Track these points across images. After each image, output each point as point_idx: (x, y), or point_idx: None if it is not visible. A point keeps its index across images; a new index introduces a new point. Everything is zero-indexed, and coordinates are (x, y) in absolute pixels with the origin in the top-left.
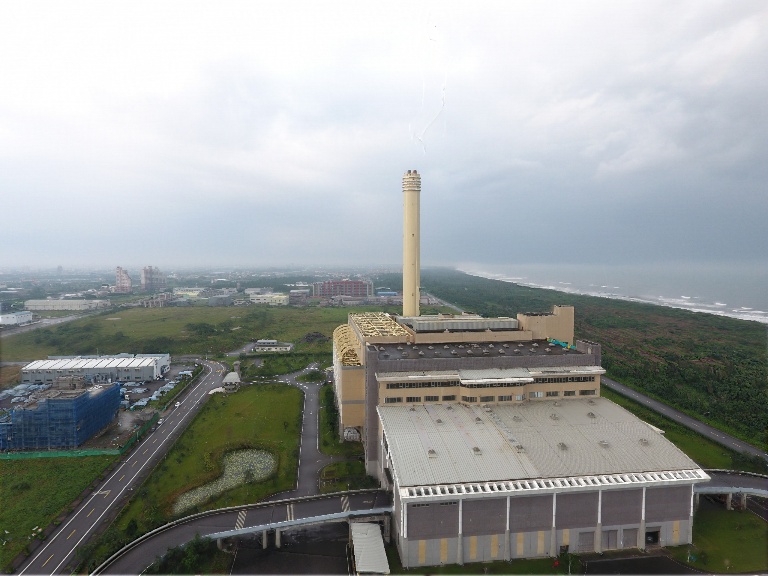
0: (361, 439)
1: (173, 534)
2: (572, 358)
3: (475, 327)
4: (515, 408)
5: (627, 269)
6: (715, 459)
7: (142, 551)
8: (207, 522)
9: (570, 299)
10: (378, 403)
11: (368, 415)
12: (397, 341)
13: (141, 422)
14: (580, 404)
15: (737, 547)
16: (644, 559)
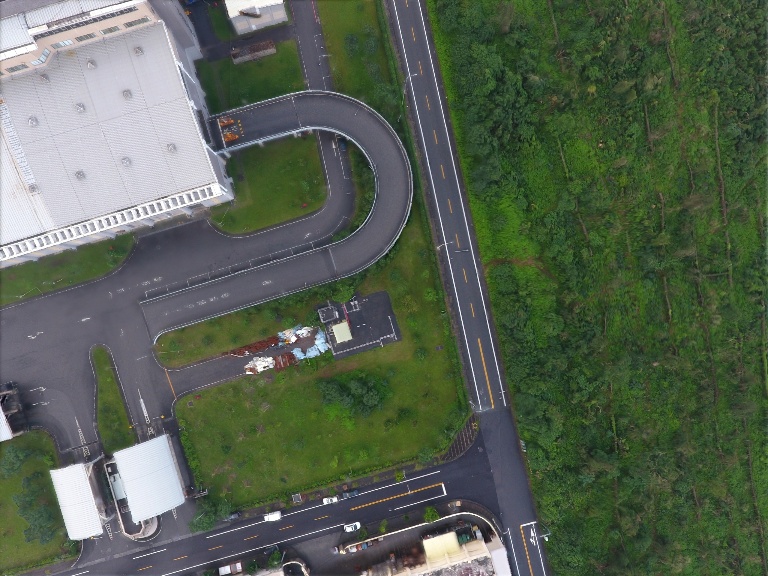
0: None
1: None
2: None
3: None
4: (34, 86)
5: None
6: (343, 22)
7: None
8: None
9: None
10: None
11: None
12: None
13: None
14: (123, 55)
15: (267, 200)
16: (186, 226)
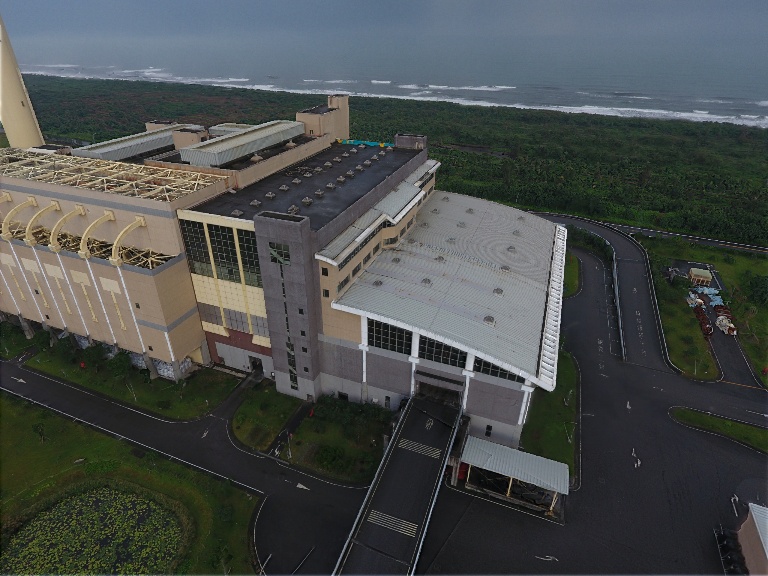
0: (199, 363)
1: None
2: (420, 157)
3: (272, 142)
4: (425, 230)
5: (129, 42)
6: None
7: None
8: None
9: (81, 86)
10: (320, 298)
11: (308, 323)
12: (215, 193)
13: None
14: (442, 204)
15: None
16: None
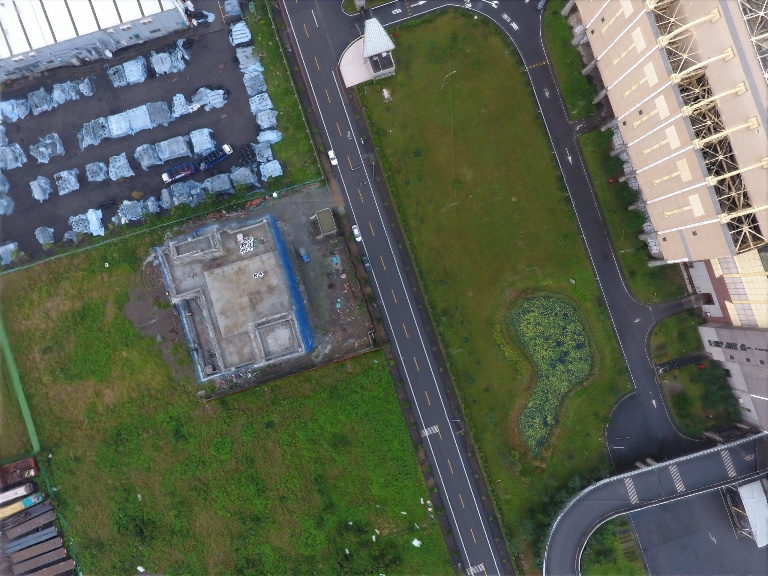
0: None
1: (577, 514)
2: None
3: None
4: None
5: None
6: None
7: (563, 535)
8: (600, 496)
9: None
10: None
11: None
12: None
13: (327, 240)
14: None
15: None
16: None
